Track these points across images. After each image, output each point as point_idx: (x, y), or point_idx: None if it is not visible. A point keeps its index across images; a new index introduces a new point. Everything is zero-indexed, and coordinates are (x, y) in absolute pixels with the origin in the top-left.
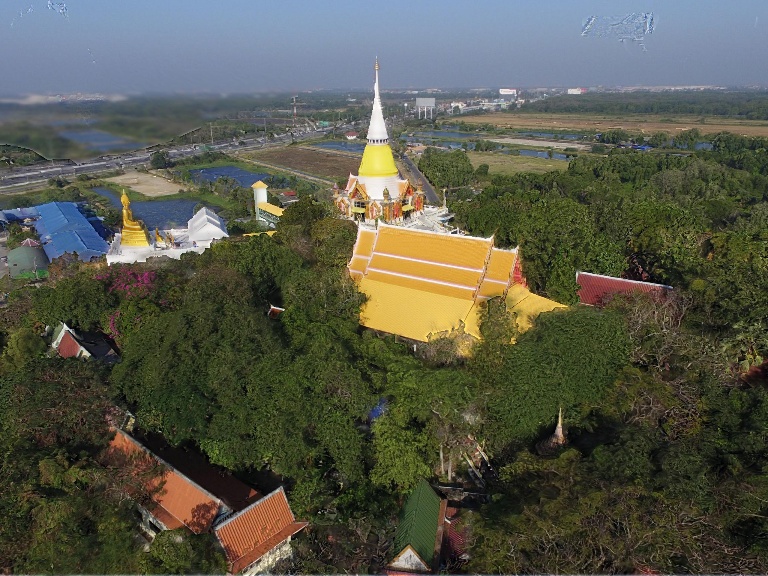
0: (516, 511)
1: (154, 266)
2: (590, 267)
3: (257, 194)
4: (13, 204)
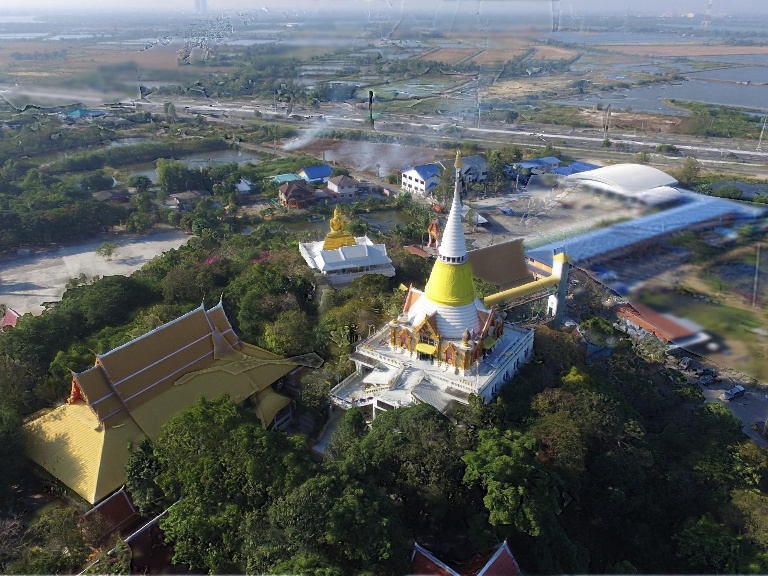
0: None
1: (275, 262)
2: None
3: (554, 265)
4: (721, 191)
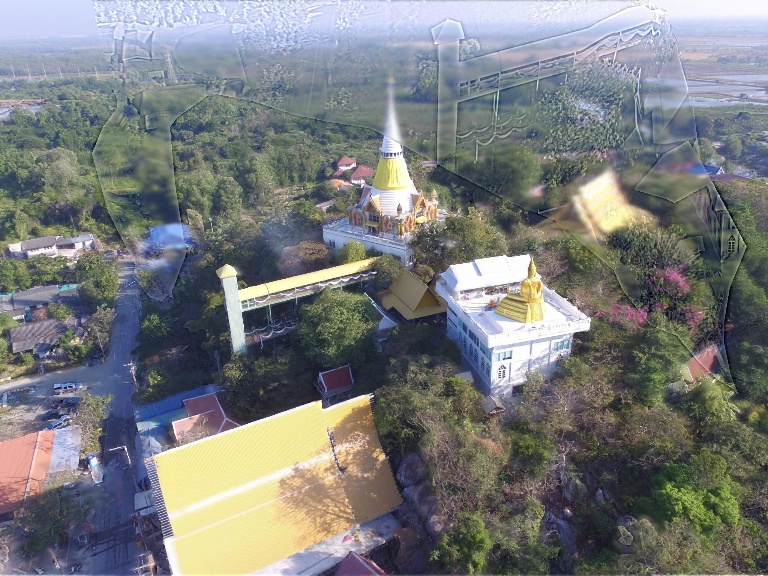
0: (760, 231)
1: None
2: None
3: None
4: None
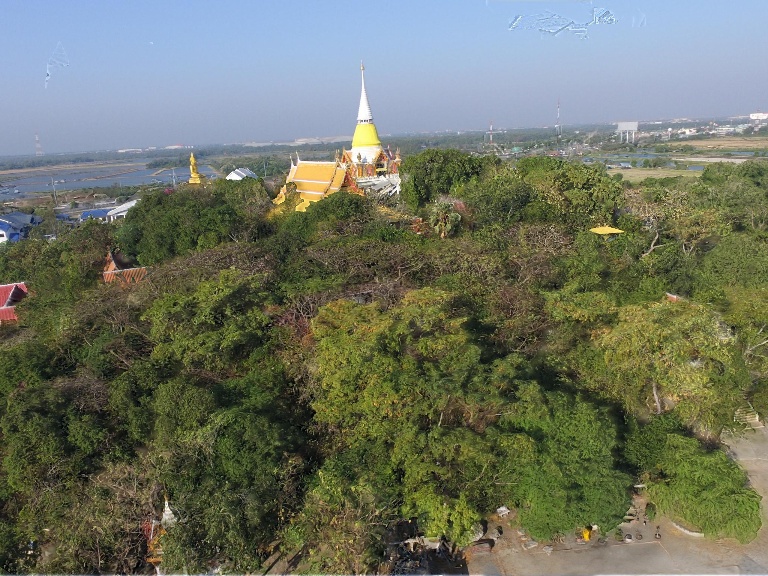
0: None
1: None
2: (452, 196)
3: None
4: None
